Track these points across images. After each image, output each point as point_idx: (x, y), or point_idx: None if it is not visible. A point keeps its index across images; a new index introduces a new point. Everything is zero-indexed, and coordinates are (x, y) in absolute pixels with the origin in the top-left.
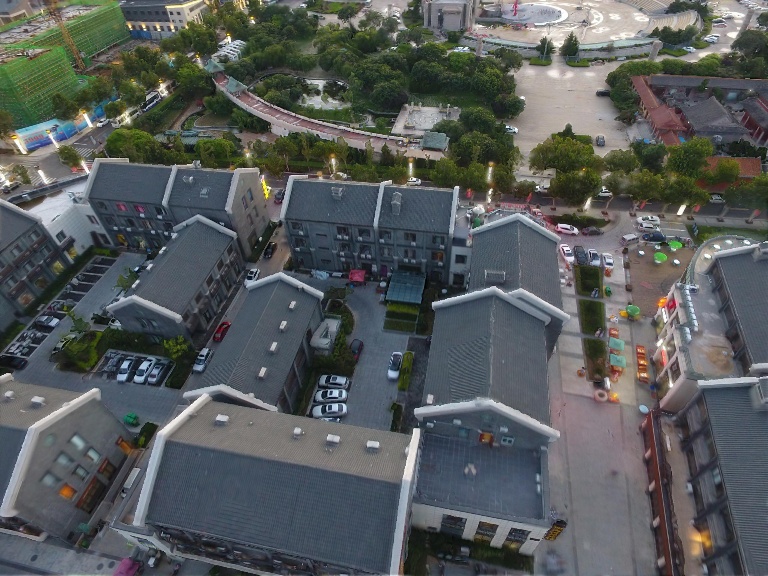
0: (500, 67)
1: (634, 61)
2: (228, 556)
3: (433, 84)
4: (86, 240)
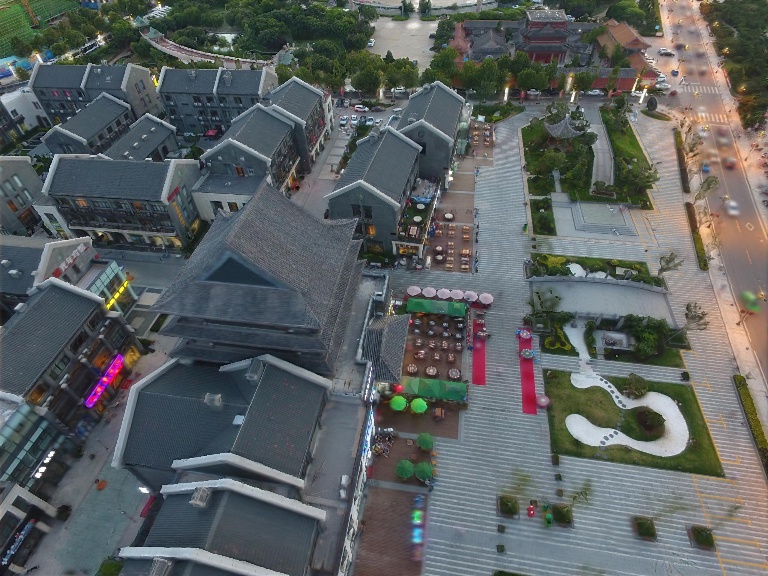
0: (362, 19)
1: (460, 13)
2: (96, 224)
3: (309, 32)
4: (33, 121)
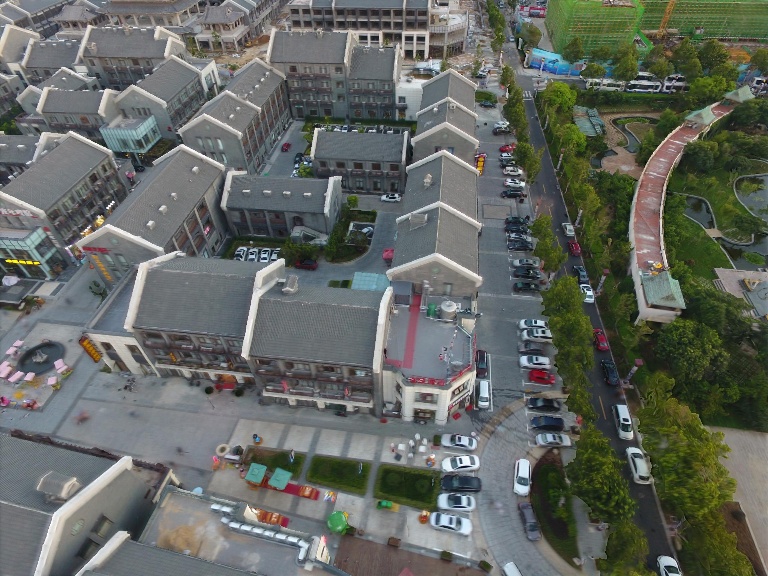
0: None
1: None
2: None
3: None
4: None
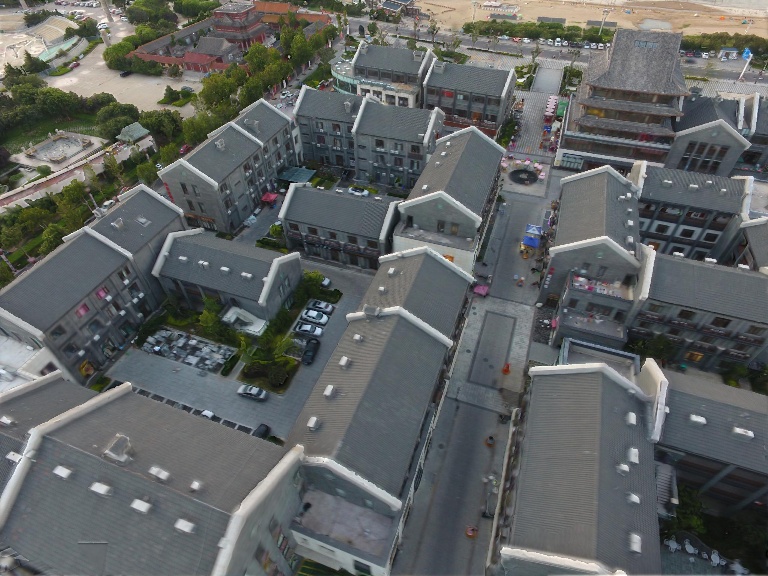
0: None
1: (109, 47)
2: None
3: None
4: None
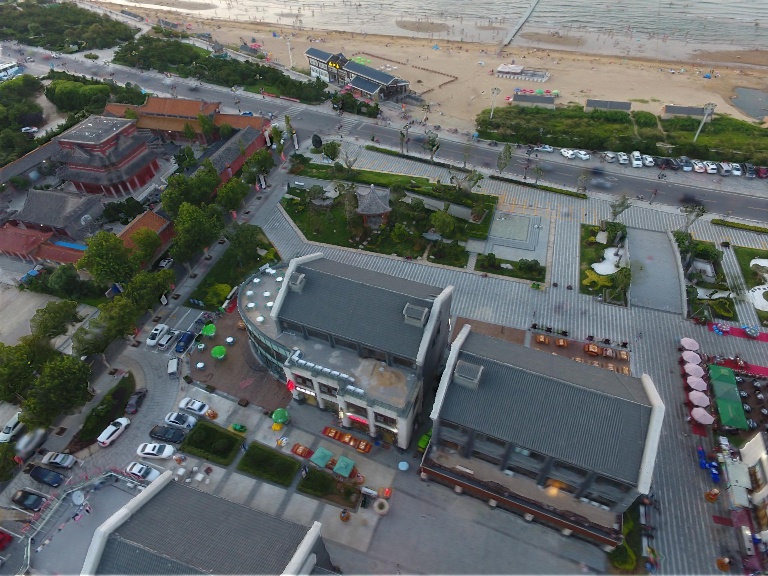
0: None
1: None
2: None
3: None
4: None
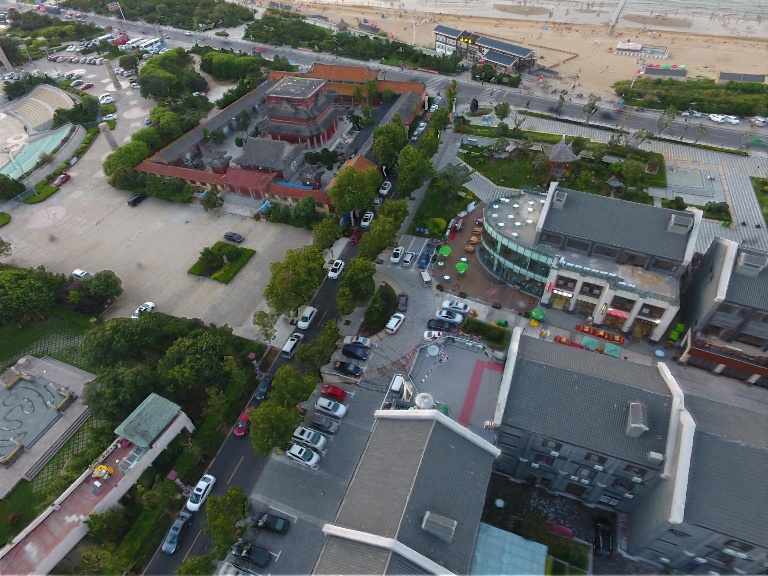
0: None
1: (112, 154)
2: None
3: None
4: None
